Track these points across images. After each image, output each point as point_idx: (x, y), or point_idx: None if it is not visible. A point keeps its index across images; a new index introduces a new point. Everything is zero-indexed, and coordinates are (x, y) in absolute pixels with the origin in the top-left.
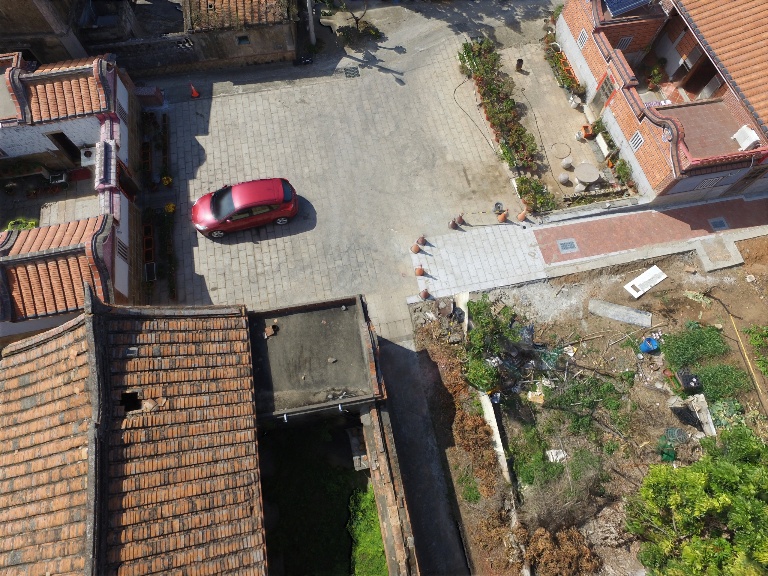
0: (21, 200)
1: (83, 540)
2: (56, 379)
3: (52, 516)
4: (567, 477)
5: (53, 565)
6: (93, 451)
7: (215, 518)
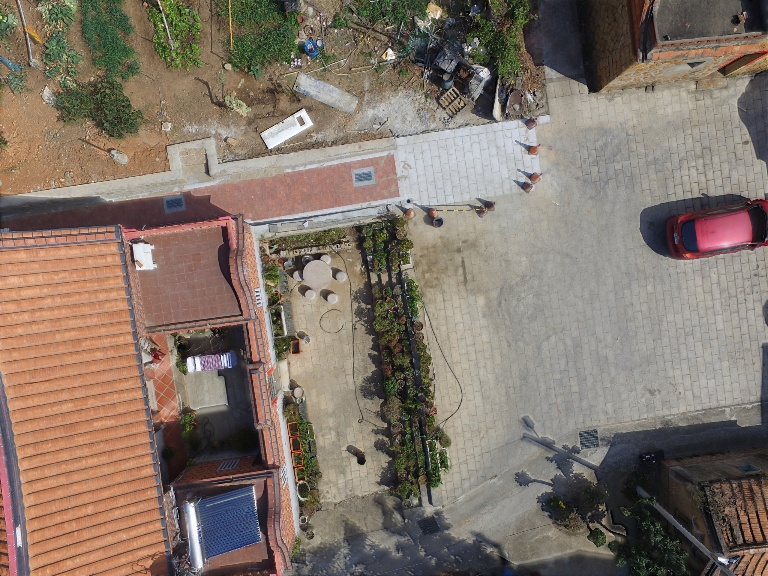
0: None
1: None
2: None
3: None
4: None
5: None
6: None
7: None
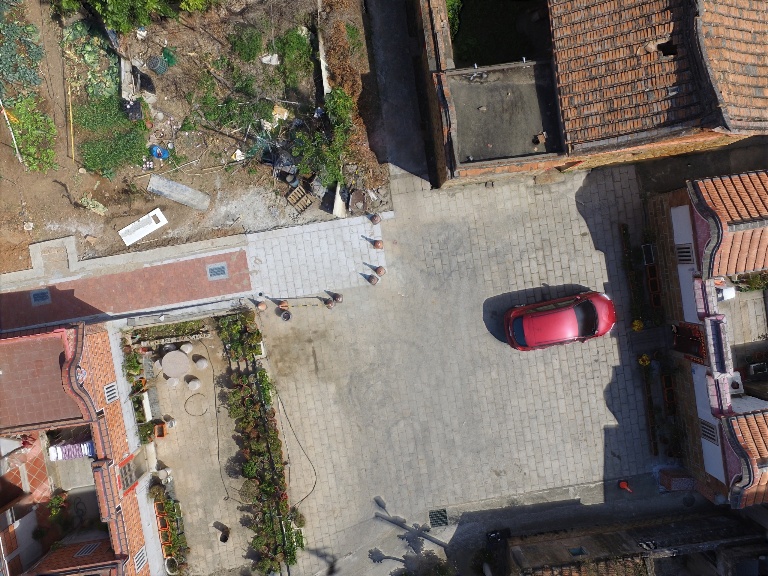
0: None
1: None
2: (734, 79)
3: None
4: (274, 15)
5: None
6: None
7: None
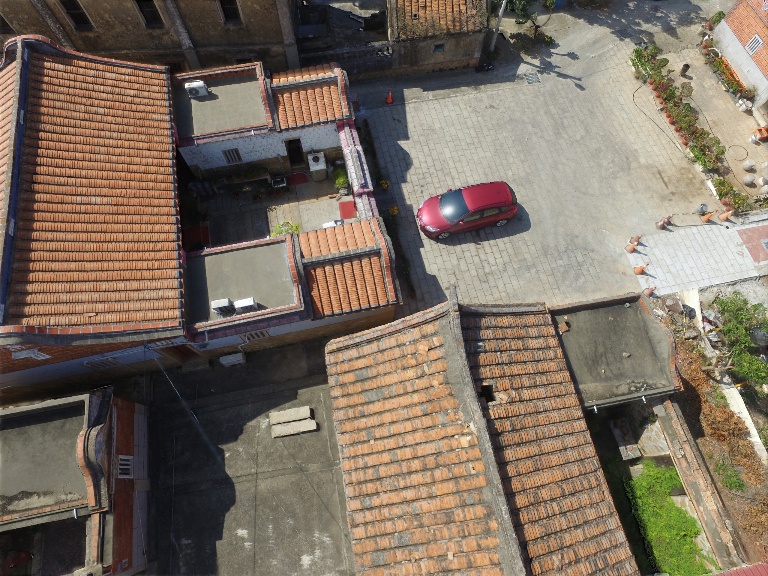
0: (246, 204)
1: (486, 521)
2: (406, 373)
3: (438, 500)
4: None
5: (454, 545)
6: (488, 439)
7: (581, 502)
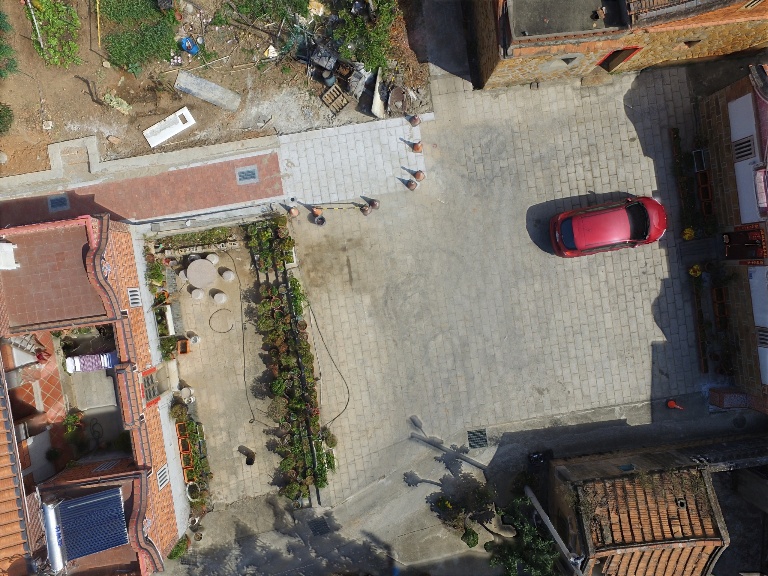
0: None
1: None
2: None
3: None
4: None
5: None
6: None
7: None
